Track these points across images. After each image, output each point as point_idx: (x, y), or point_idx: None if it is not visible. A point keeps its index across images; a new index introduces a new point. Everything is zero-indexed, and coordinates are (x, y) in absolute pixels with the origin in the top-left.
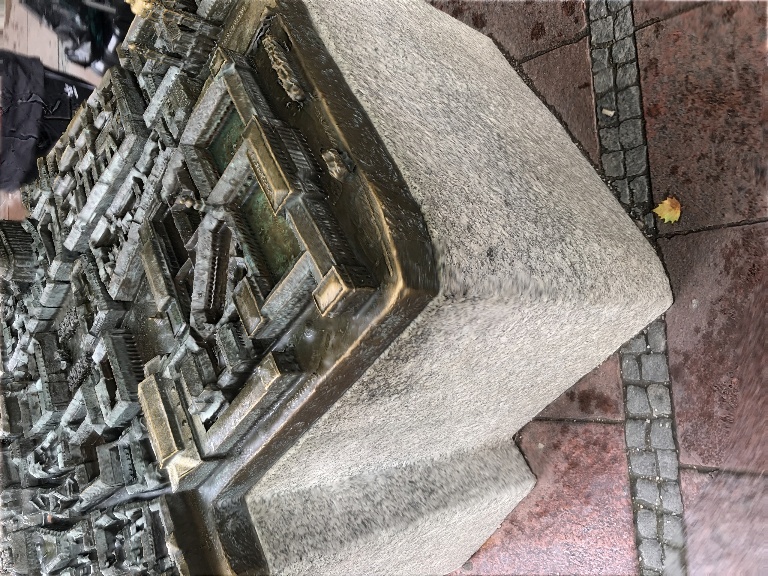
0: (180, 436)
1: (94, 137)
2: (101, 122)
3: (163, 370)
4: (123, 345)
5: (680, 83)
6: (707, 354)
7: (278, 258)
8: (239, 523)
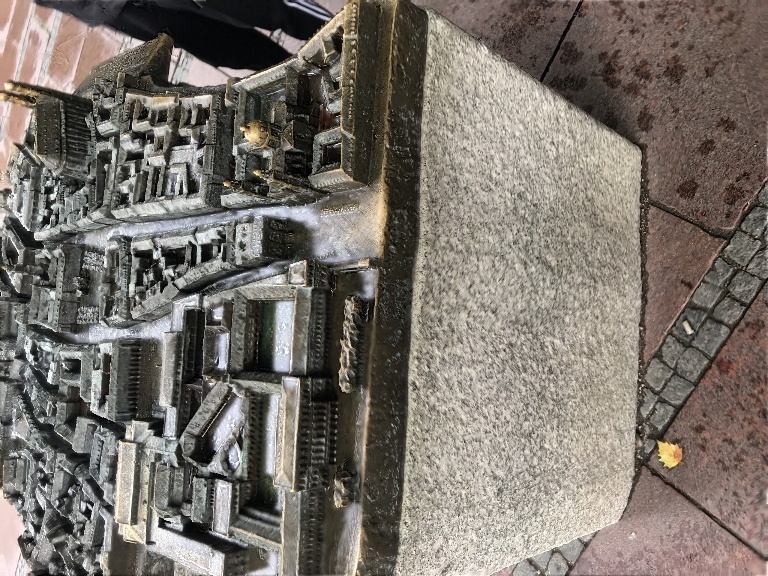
0: (137, 512)
1: (174, 139)
2: (186, 134)
3: (146, 444)
4: (128, 358)
5: (765, 365)
6: (613, 575)
7: (270, 469)
8: (162, 567)
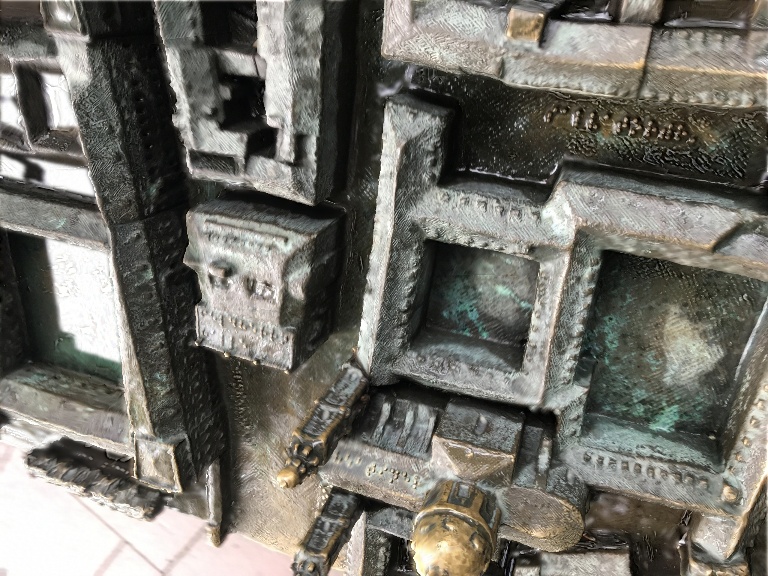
0: None
1: None
2: None
3: None
4: None
5: None
6: None
7: None
8: None
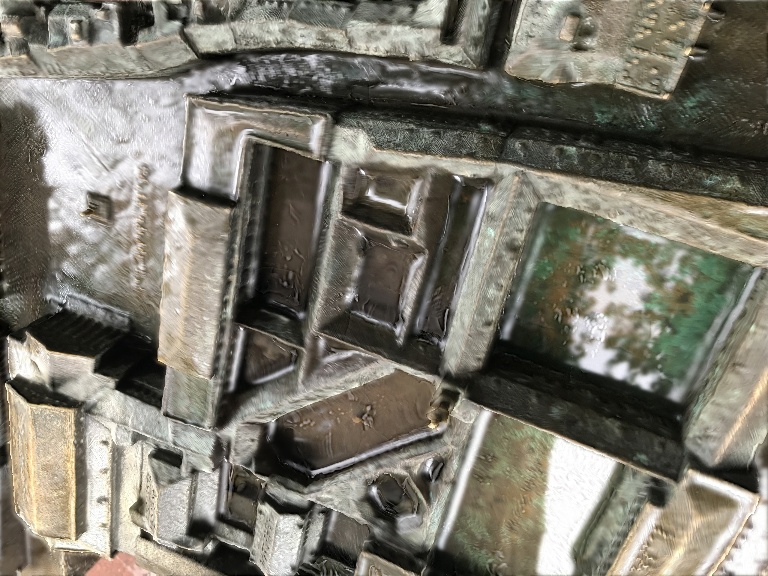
0: (85, 514)
1: None
2: None
3: (97, 406)
4: None
5: None
6: None
7: (472, 519)
8: None
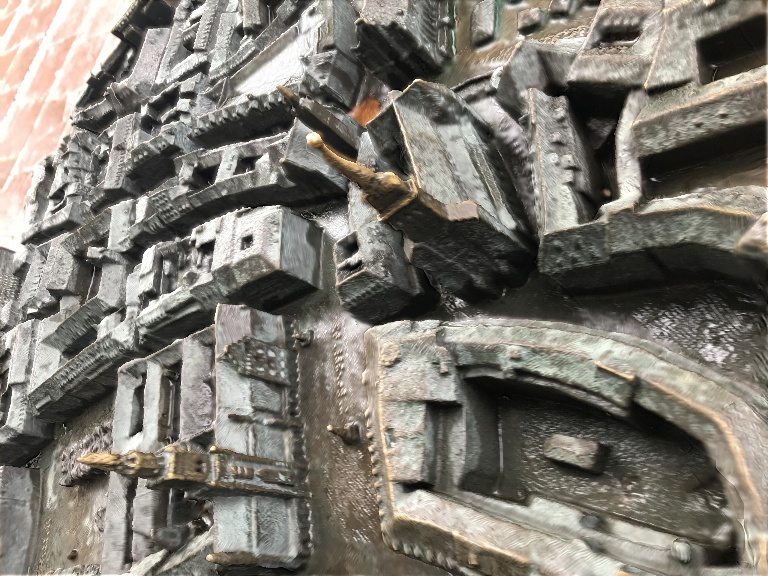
0: None
1: None
2: None
3: None
4: None
5: None
6: None
7: None
8: None
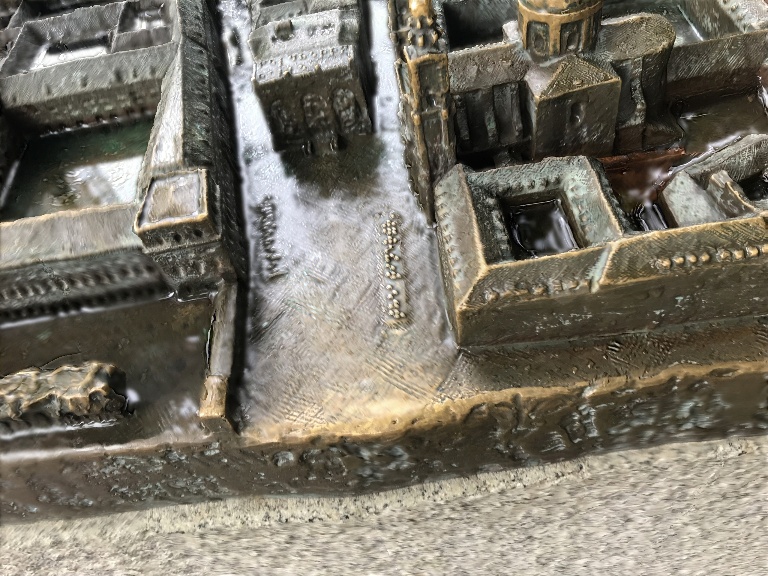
0: None
1: None
2: None
3: None
4: None
5: None
6: None
7: None
8: None
